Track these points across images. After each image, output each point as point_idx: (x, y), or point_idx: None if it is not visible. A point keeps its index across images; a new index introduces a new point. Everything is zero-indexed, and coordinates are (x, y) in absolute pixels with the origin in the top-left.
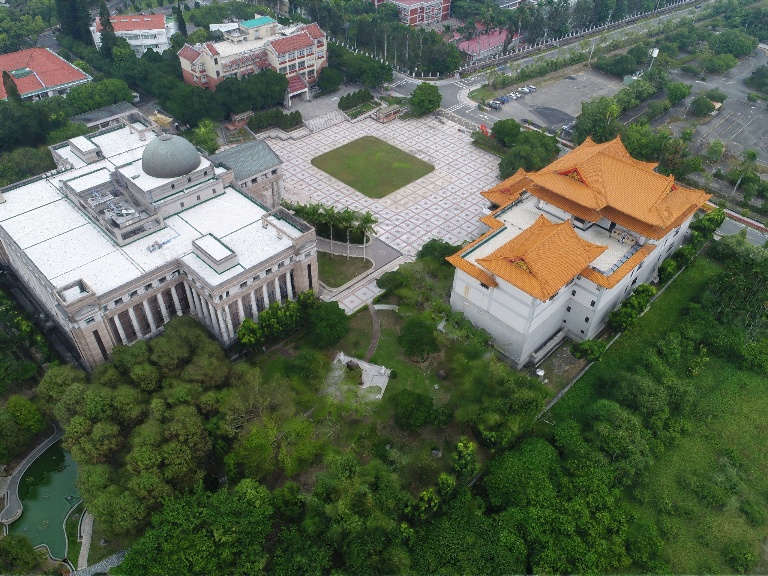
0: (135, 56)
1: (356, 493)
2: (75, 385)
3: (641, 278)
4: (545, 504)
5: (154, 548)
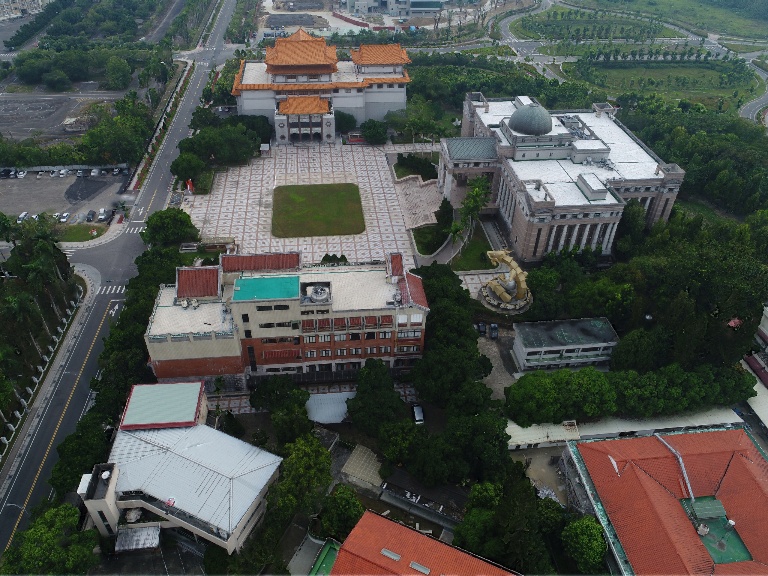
0: (478, 423)
1: (511, 75)
2: None
3: None
4: None
5: None
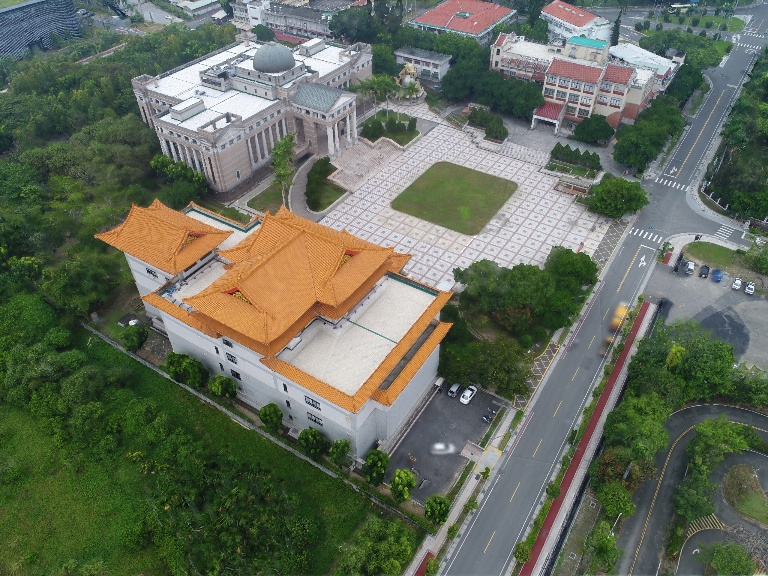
0: None
1: None
2: (110, 118)
3: (257, 391)
4: None
5: (0, 167)
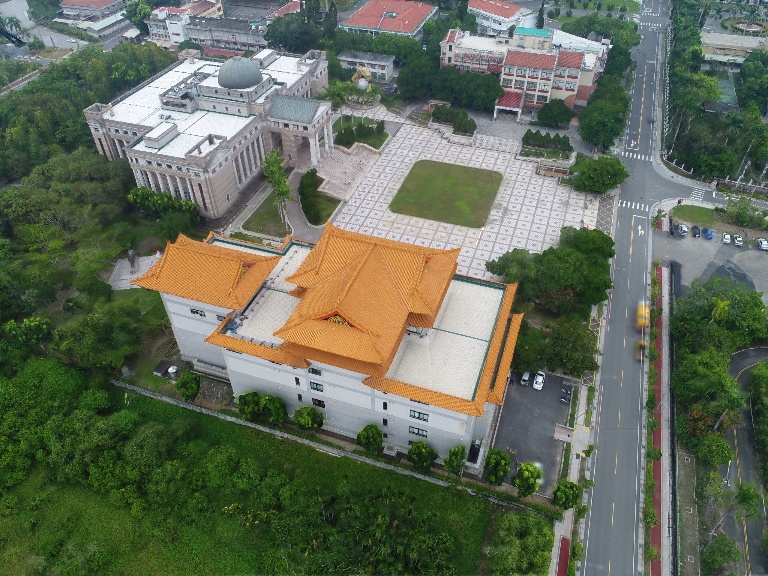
0: None
1: None
2: (63, 154)
3: (344, 415)
4: (7, 395)
5: None
